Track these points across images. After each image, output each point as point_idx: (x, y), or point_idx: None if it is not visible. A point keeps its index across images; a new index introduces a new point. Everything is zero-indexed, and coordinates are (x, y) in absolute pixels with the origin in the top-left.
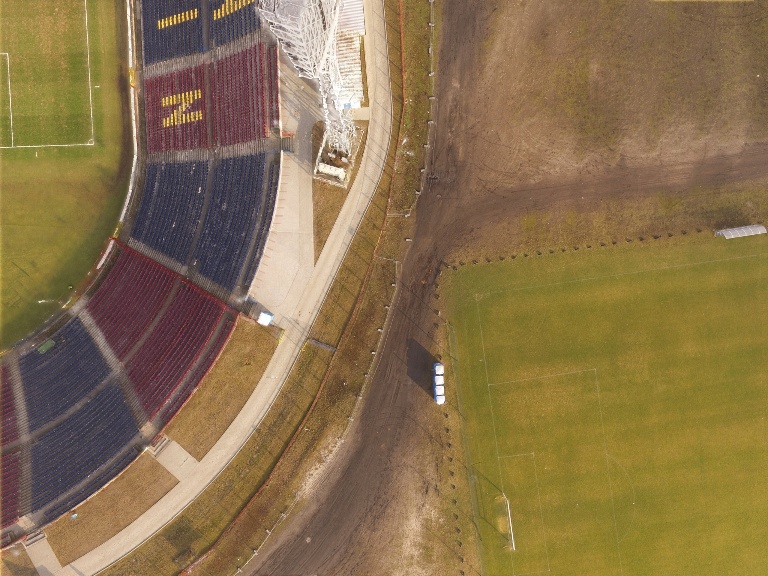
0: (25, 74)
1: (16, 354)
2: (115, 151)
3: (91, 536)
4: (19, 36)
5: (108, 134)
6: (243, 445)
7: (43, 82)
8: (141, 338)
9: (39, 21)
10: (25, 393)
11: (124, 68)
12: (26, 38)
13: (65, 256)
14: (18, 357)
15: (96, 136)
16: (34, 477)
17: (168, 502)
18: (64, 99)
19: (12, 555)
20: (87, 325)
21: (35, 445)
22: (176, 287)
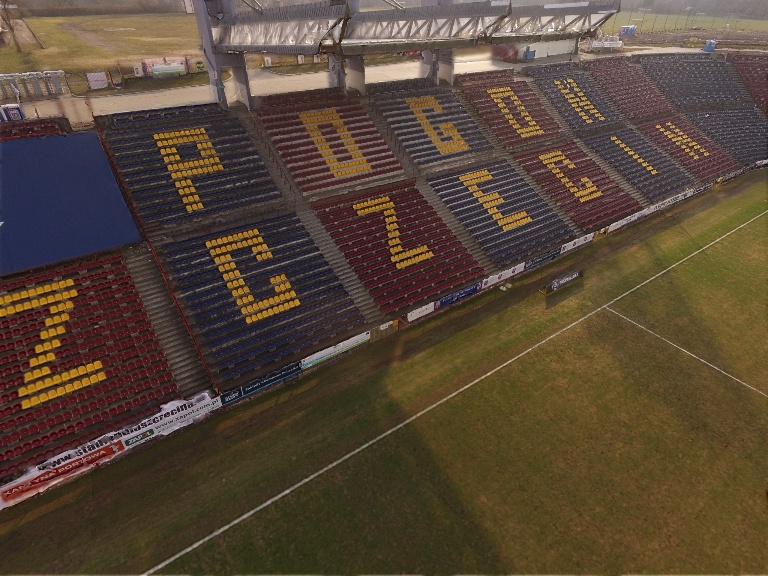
0: None
1: None
2: None
3: None
4: None
5: None
6: (767, 50)
7: None
8: None
9: None
10: None
11: None
12: None
13: None
14: None
15: None
16: None
17: None
18: None
19: None
20: None
21: None
22: None
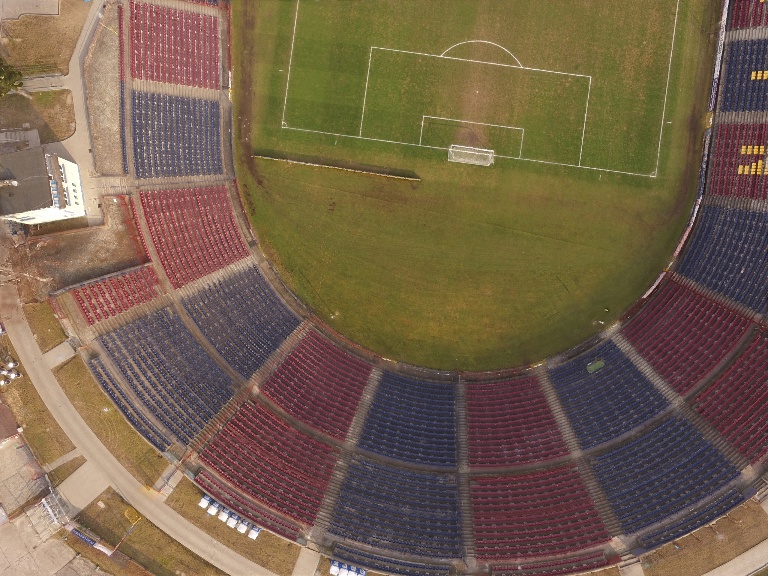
0: (604, 99)
1: (544, 366)
2: (675, 187)
3: (685, 569)
4: (605, 62)
5: (671, 169)
6: None
7: (619, 109)
8: (704, 376)
9: (626, 51)
10: (564, 408)
11: (697, 109)
12: (611, 65)
13: (607, 279)
14: (545, 369)
15: (660, 169)
16: (610, 498)
17: (764, 549)
18: (636, 129)
19: (606, 574)
20: (624, 351)
21: (594, 464)
22: (748, 333)
